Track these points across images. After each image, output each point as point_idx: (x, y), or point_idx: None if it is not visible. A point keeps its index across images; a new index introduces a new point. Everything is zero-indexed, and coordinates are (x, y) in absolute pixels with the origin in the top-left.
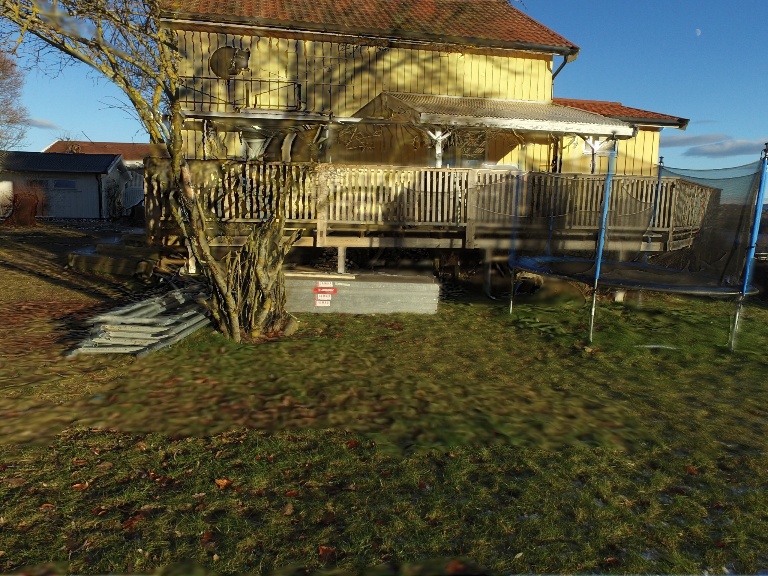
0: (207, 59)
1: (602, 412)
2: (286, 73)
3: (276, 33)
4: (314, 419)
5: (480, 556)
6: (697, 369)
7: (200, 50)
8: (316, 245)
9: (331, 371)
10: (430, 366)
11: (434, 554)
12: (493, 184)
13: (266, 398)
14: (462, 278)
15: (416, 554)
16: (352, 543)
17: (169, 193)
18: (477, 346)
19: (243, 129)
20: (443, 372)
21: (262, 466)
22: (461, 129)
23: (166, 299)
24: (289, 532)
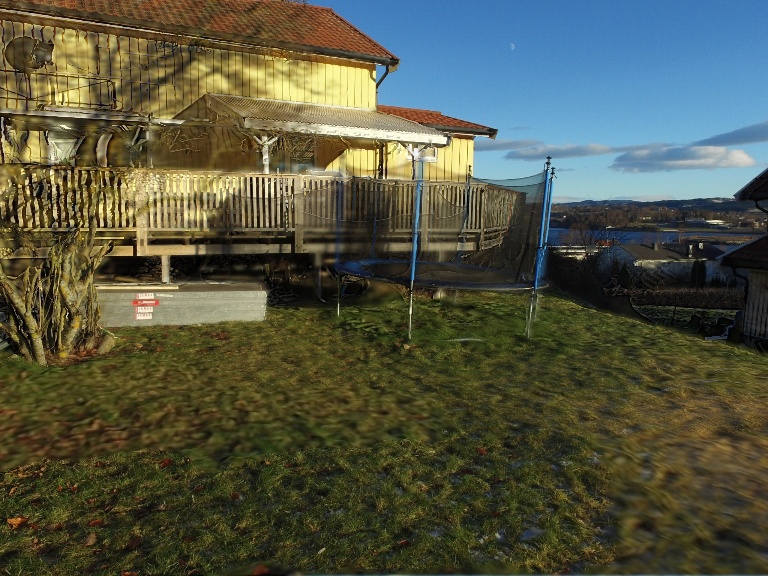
0: (1, 49)
1: (413, 406)
2: (97, 69)
3: (83, 26)
4: (126, 441)
5: (285, 557)
6: (499, 358)
7: None
8: (136, 254)
9: (148, 388)
10: (254, 375)
11: (241, 562)
12: (319, 190)
13: (73, 424)
14: (293, 282)
15: (223, 565)
16: (158, 564)
17: None
18: (303, 351)
19: (49, 128)
20: (267, 380)
21: (63, 498)
22: (289, 133)
23: None
24: (90, 563)
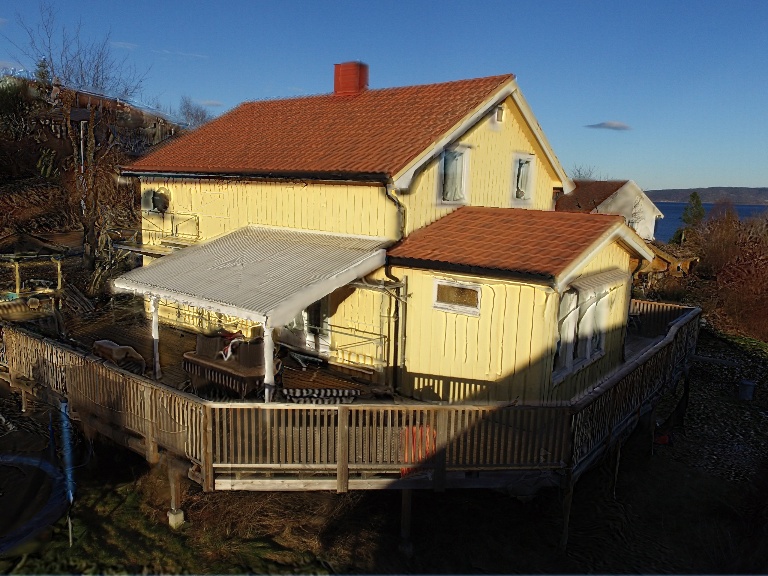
0: None
1: None
2: None
3: None
4: None
5: None
6: None
7: (151, 190)
8: None
9: None
10: None
11: None
12: None
13: None
14: None
15: None
16: None
17: None
18: None
19: None
20: None
21: None
22: None
23: None
24: None
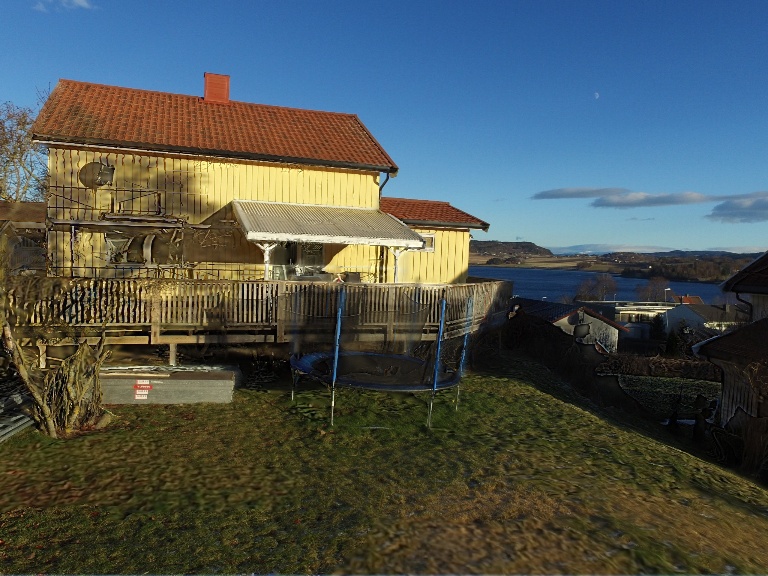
0: (76, 172)
1: (283, 484)
2: (148, 184)
3: (139, 152)
4: (78, 498)
5: (125, 574)
6: (390, 446)
7: (70, 165)
8: (150, 343)
9: (113, 460)
10: (192, 452)
11: (101, 575)
12: (298, 292)
13: (54, 484)
14: (275, 365)
15: (92, 575)
16: (58, 572)
17: (24, 304)
18: (241, 433)
19: (106, 232)
20: (198, 457)
21: (28, 531)
22: None
23: (5, 402)
24: (26, 568)
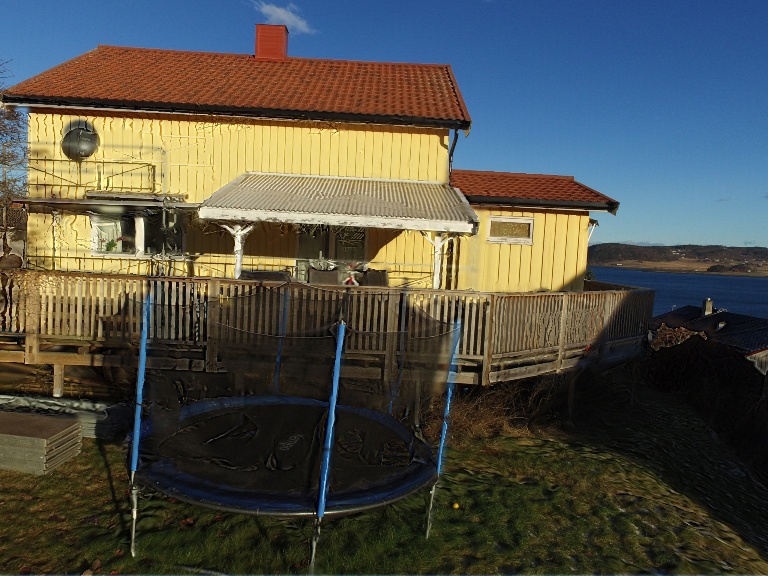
0: (59, 141)
1: None
2: (140, 154)
3: (128, 113)
4: None
5: None
6: None
7: (52, 132)
8: (24, 362)
9: None
10: None
11: None
12: (239, 297)
13: None
14: None
15: None
16: None
17: None
18: None
19: None
20: None
21: None
22: None
23: None
24: None
